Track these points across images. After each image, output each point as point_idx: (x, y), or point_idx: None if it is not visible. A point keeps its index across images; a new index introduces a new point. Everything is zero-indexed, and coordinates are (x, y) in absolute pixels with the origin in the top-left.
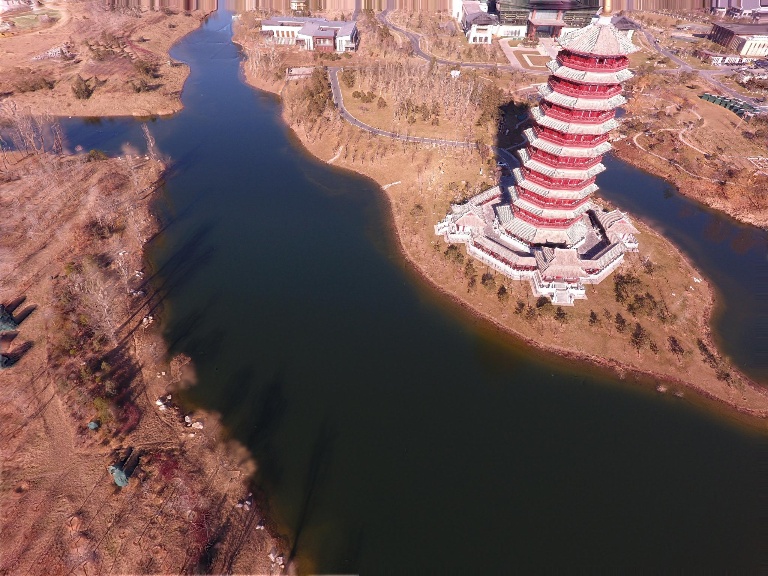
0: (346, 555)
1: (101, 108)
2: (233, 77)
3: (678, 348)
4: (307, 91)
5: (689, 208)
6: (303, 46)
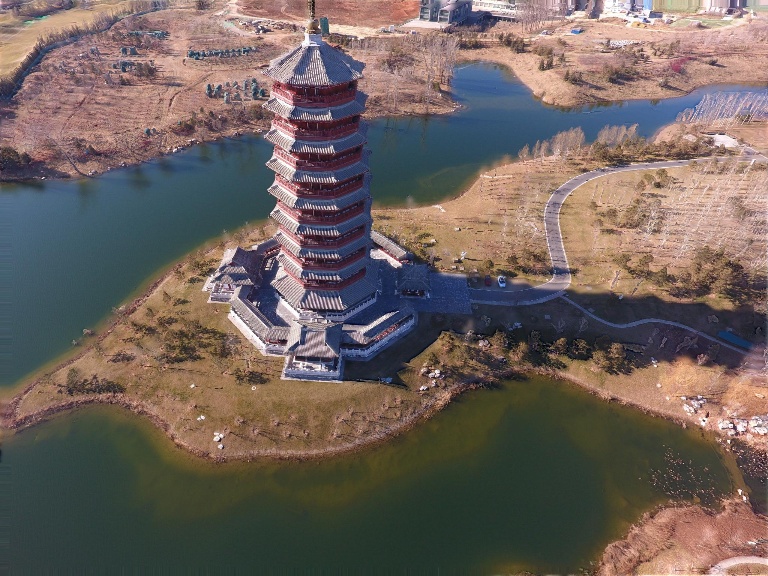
0: (80, 190)
1: (534, 79)
2: None
3: (119, 358)
4: (626, 139)
5: None
6: None
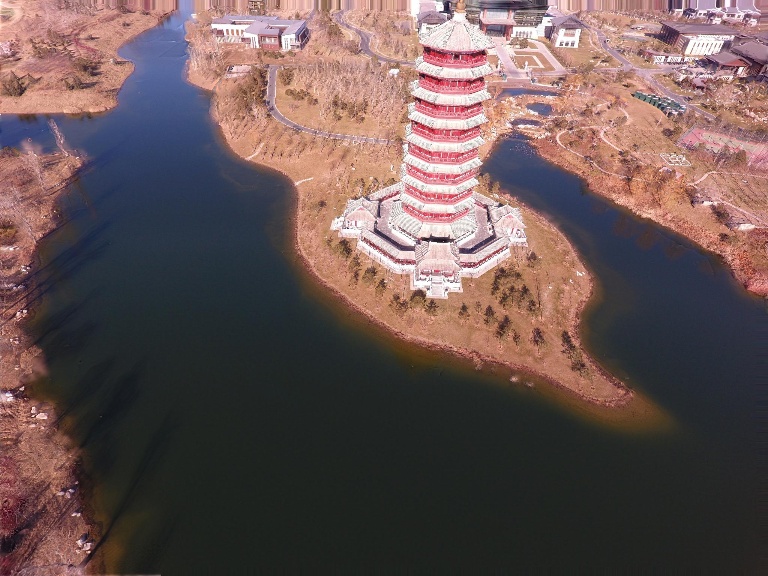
0: (156, 541)
1: (32, 105)
2: (176, 75)
3: (540, 339)
4: (239, 89)
5: (597, 204)
6: (249, 44)
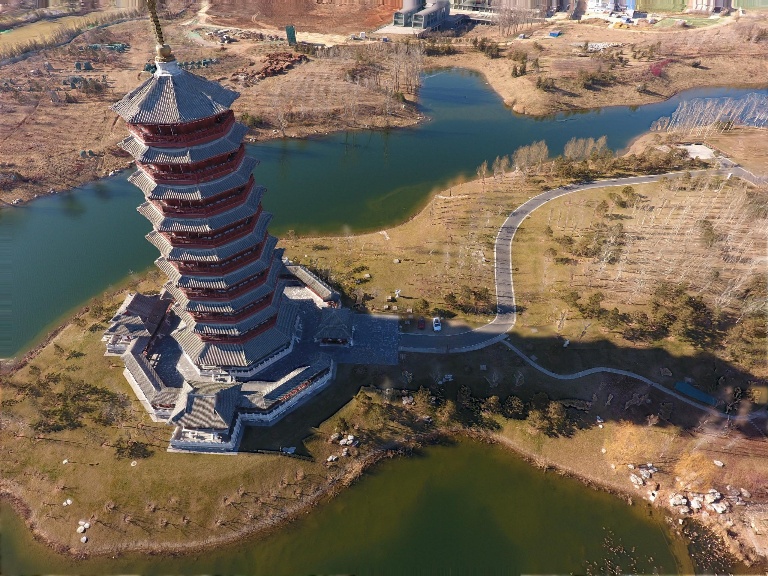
0: (0, 221)
1: (506, 87)
2: None
3: None
4: (593, 153)
5: None
6: None
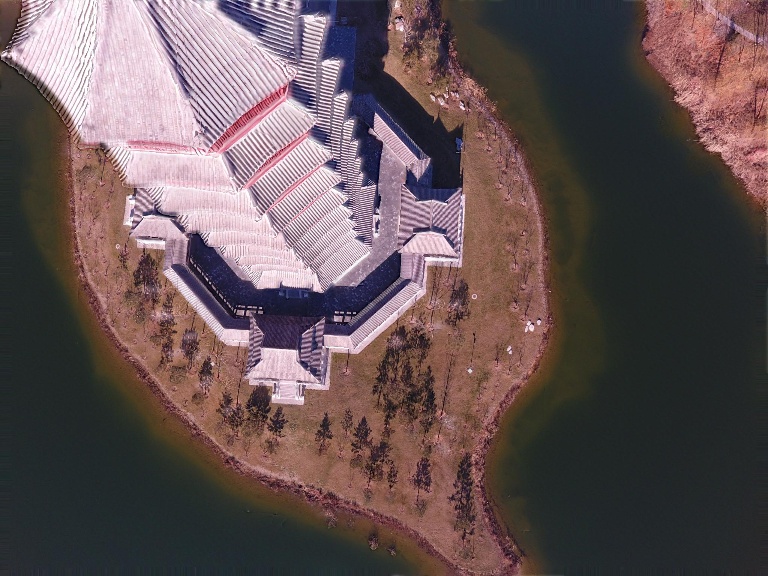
0: None
1: None
2: None
3: (425, 479)
4: None
5: (642, 88)
6: None
